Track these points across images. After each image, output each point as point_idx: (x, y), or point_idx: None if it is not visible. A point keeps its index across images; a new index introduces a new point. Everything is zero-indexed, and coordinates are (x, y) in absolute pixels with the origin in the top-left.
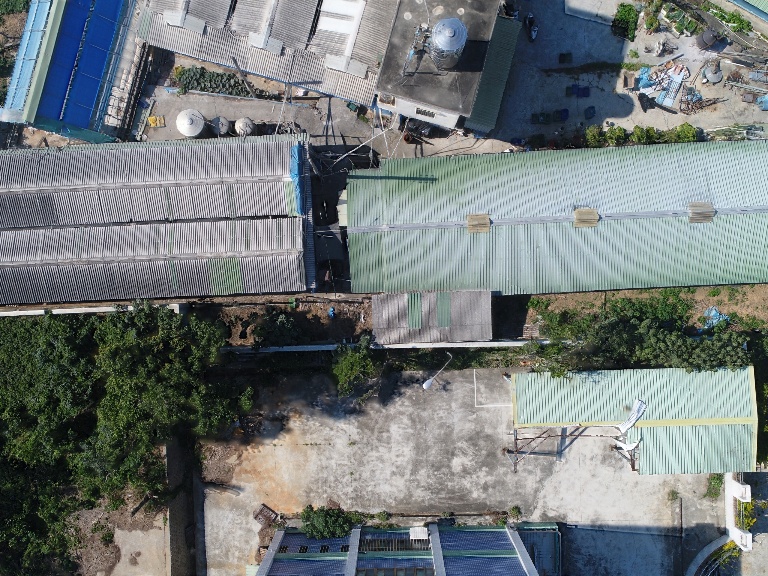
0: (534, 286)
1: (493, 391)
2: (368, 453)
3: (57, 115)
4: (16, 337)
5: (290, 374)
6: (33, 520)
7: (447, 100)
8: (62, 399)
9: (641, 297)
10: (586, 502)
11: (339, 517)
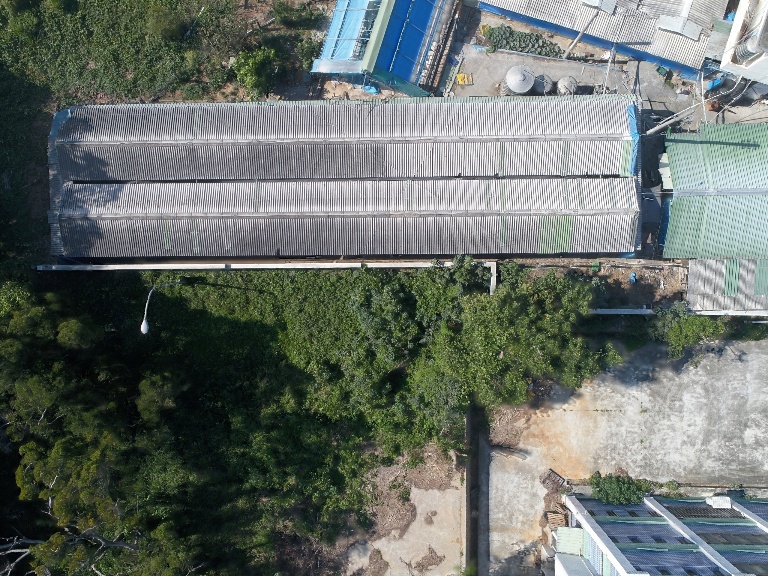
0: None
1: None
2: (659, 421)
3: (388, 66)
4: (321, 290)
5: None
6: (333, 475)
7: None
8: (383, 352)
9: None
10: None
11: (630, 484)
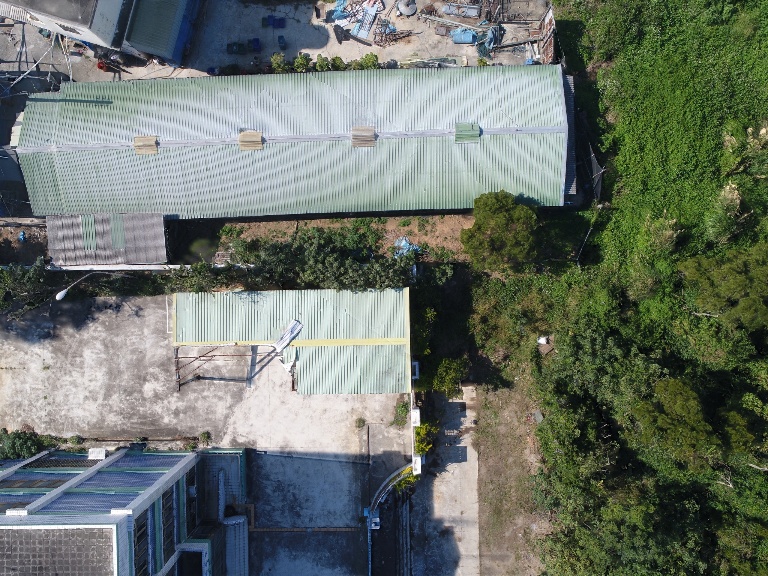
0: (210, 210)
1: None
2: (61, 377)
3: None
4: None
5: None
6: None
7: (67, 11)
8: None
9: (333, 226)
10: (275, 428)
11: (29, 440)
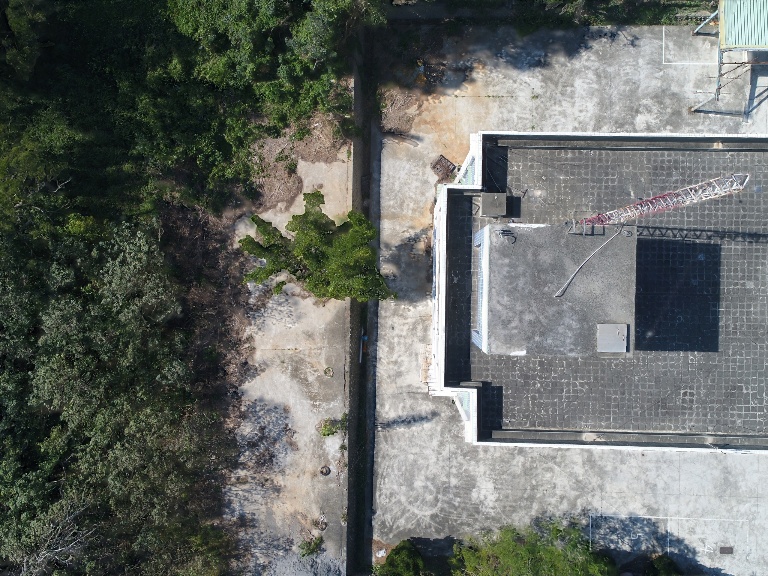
0: None
1: (682, 48)
2: (551, 107)
3: None
4: None
5: (476, 24)
6: (219, 143)
7: None
8: (264, 4)
9: None
10: None
11: None
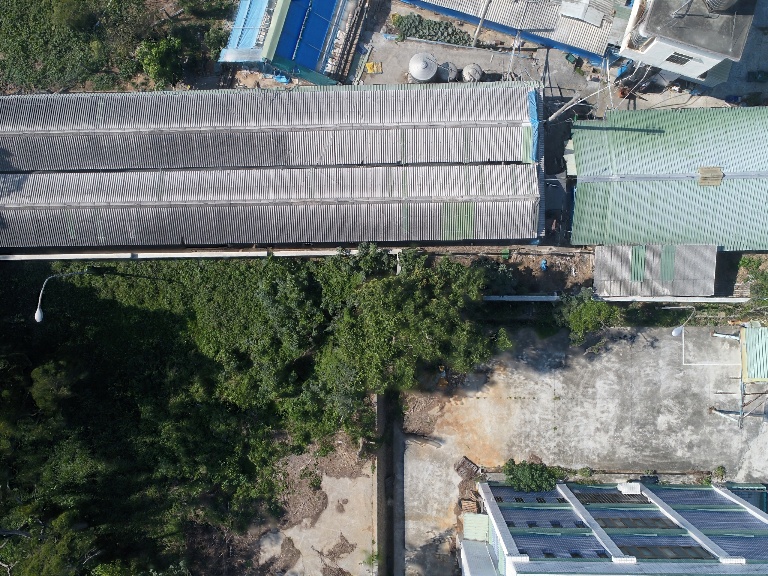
0: (758, 242)
1: (701, 349)
2: (573, 408)
3: (290, 55)
4: (231, 279)
5: (497, 326)
6: (243, 464)
7: (717, 43)
8: (287, 340)
9: None
10: None
11: (543, 471)
